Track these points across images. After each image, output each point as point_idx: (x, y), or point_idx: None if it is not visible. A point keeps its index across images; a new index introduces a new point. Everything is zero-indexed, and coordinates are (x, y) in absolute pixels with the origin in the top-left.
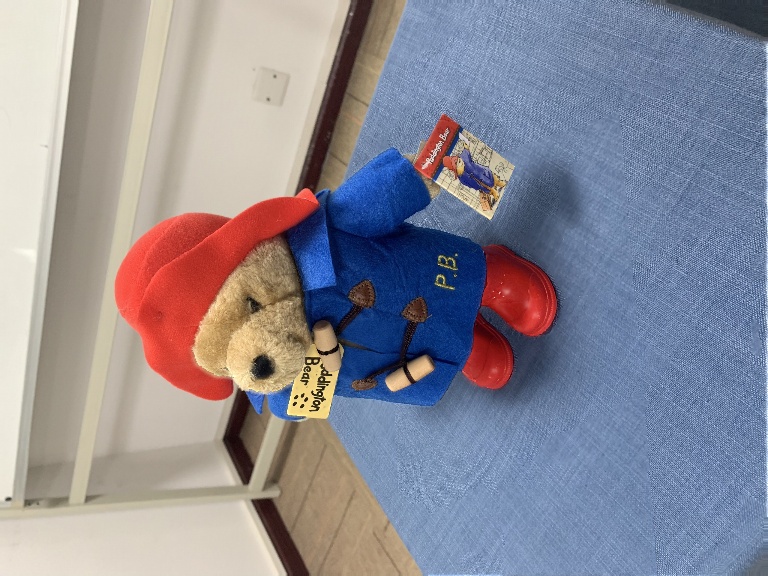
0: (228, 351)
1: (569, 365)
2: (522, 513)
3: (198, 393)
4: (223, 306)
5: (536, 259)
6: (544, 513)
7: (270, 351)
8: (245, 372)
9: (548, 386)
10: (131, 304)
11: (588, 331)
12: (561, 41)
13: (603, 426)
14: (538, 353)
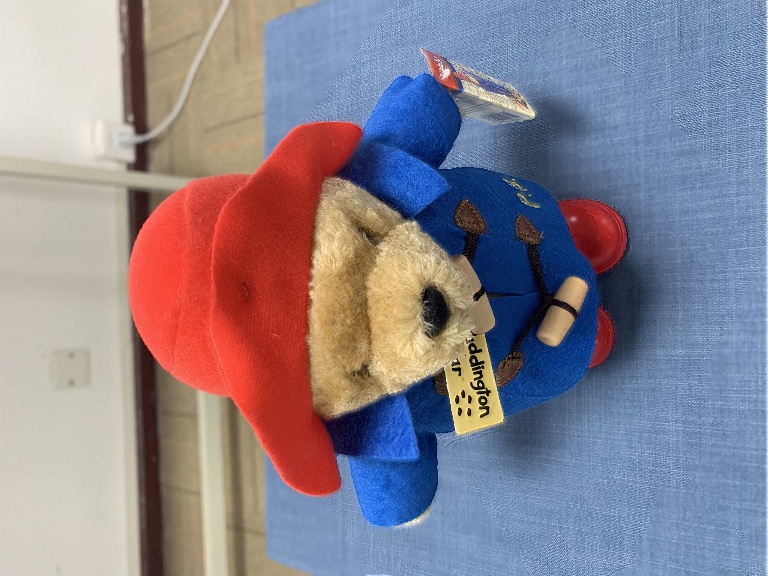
0: (373, 308)
1: (676, 264)
2: (739, 476)
3: (304, 484)
4: (336, 242)
5: (562, 196)
6: (767, 450)
7: (435, 276)
8: (415, 325)
9: (667, 305)
10: (191, 287)
11: (673, 215)
12: (463, 7)
13: (763, 292)
14: (630, 282)
